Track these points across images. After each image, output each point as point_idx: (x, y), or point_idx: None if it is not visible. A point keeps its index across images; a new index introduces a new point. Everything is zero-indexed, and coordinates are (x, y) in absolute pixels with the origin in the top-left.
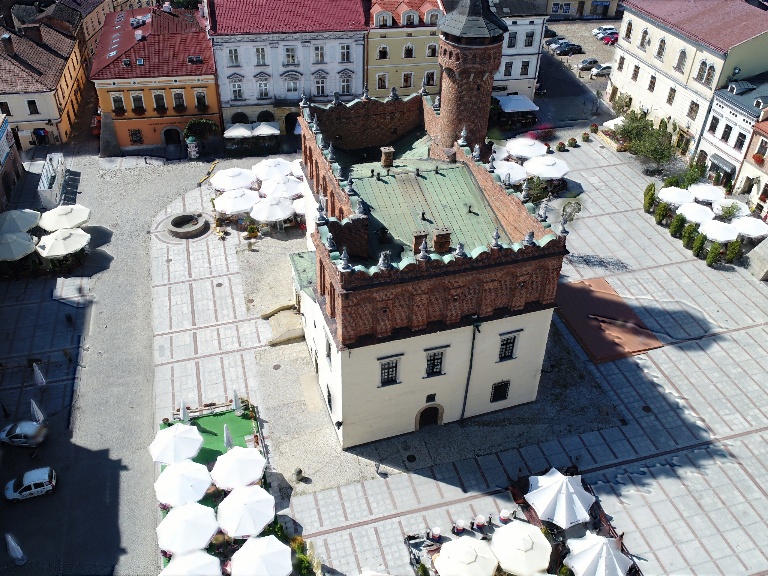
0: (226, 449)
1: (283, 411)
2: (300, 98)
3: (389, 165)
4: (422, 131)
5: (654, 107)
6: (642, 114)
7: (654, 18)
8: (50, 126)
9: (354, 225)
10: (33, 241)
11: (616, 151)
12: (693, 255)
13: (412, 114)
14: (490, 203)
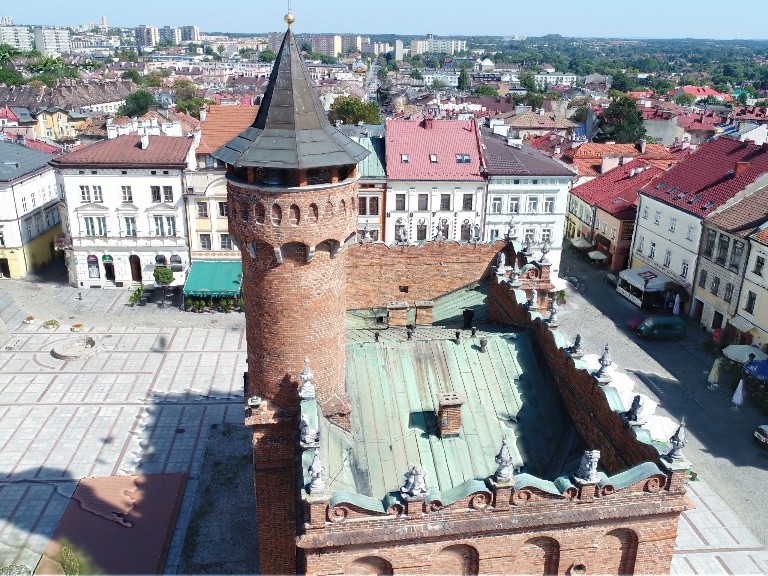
0: None
1: None
2: None
3: None
4: None
5: None
6: None
7: None
8: None
9: None
10: None
11: None
12: None
13: None
14: None
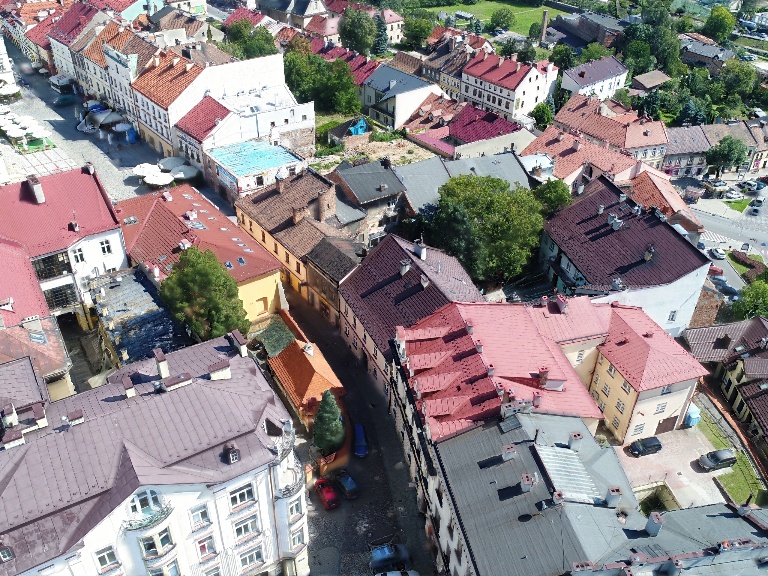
0: (29, 146)
1: (8, 155)
2: None
3: None
4: None
5: None
6: None
7: None
8: None
9: None
10: (161, 164)
11: None
12: None
13: None
14: None
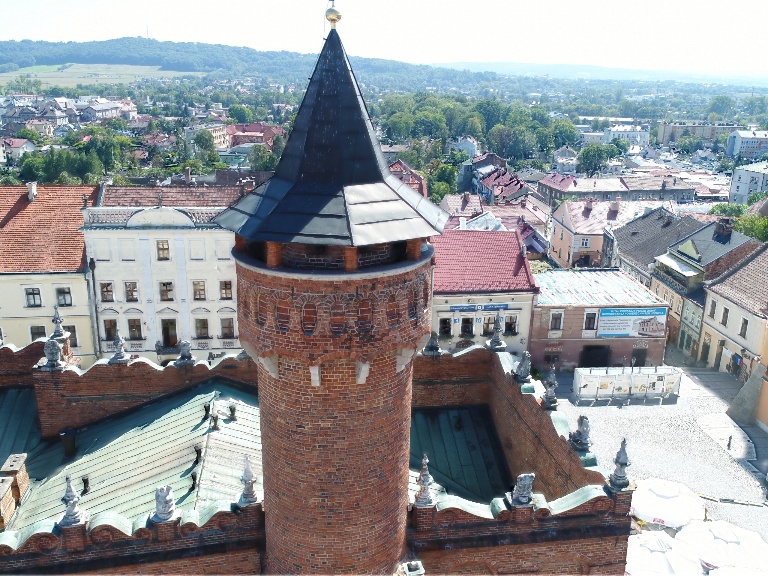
0: None
1: None
2: None
3: None
4: None
5: None
6: None
7: None
8: (745, 357)
9: None
10: None
11: None
12: None
13: None
14: None
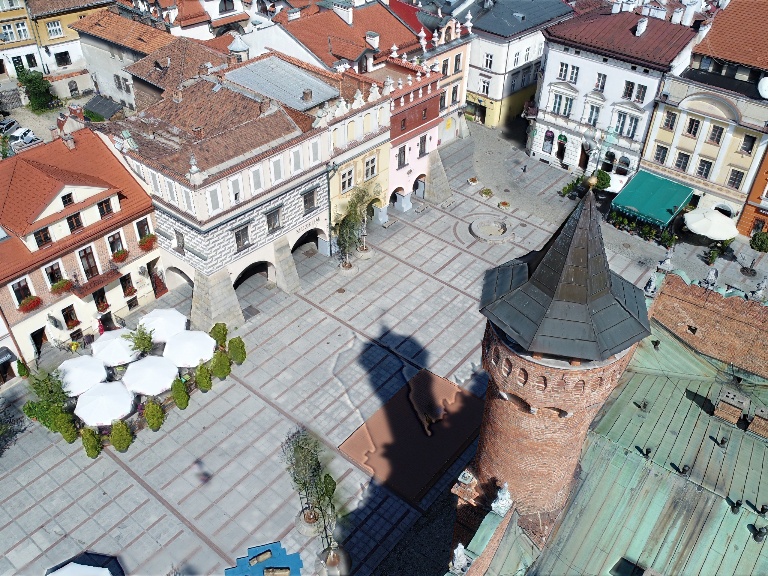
0: None
1: None
2: None
3: None
4: None
5: None
6: None
7: None
8: None
9: None
10: None
11: None
12: (225, 380)
13: None
14: None
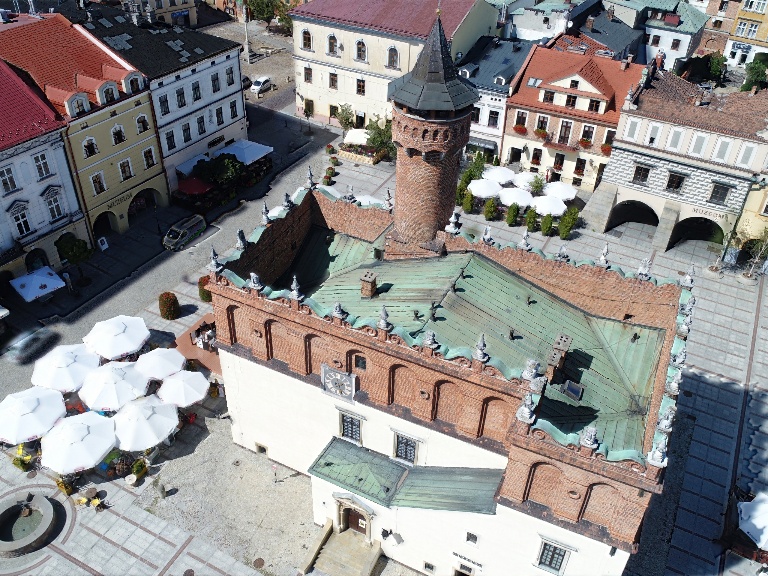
0: None
1: None
2: (0, 250)
3: (374, 293)
4: (324, 232)
5: (373, 109)
6: (357, 119)
7: (342, 22)
8: None
9: (541, 396)
10: None
11: (373, 165)
12: (544, 236)
13: (305, 217)
14: (535, 283)
